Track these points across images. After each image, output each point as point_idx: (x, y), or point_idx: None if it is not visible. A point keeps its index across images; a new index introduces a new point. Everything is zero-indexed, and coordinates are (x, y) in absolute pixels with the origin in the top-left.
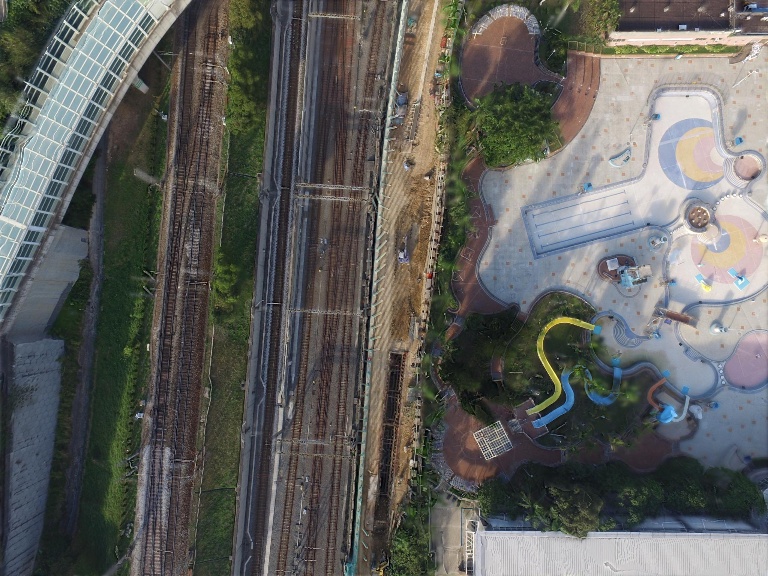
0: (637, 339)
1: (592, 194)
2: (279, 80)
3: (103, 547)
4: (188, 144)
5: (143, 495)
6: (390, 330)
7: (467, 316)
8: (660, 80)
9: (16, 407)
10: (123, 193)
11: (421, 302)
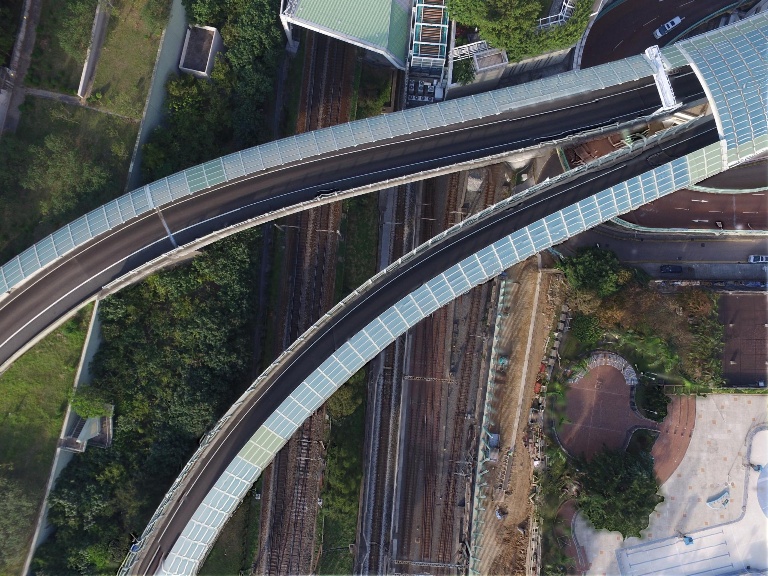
0: None
1: None
2: (370, 431)
3: None
4: (282, 526)
5: None
6: None
7: None
8: (758, 418)
9: None
10: (212, 573)
11: None
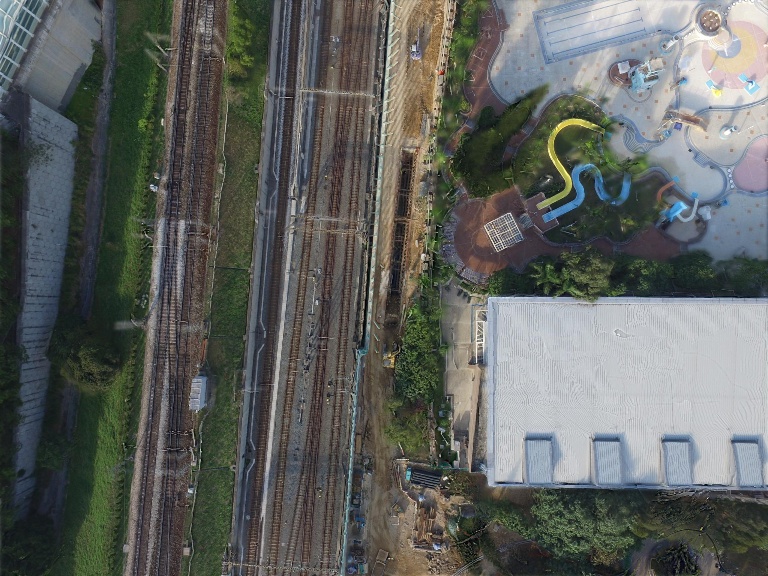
0: (647, 144)
1: (604, 1)
2: None
3: (118, 323)
4: None
5: (158, 266)
6: (402, 127)
7: (478, 118)
8: None
9: (32, 165)
10: None
11: (433, 100)
